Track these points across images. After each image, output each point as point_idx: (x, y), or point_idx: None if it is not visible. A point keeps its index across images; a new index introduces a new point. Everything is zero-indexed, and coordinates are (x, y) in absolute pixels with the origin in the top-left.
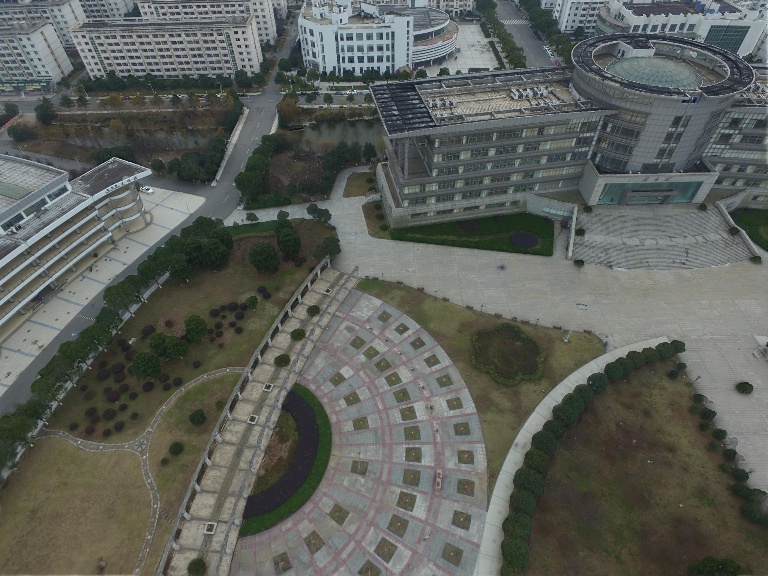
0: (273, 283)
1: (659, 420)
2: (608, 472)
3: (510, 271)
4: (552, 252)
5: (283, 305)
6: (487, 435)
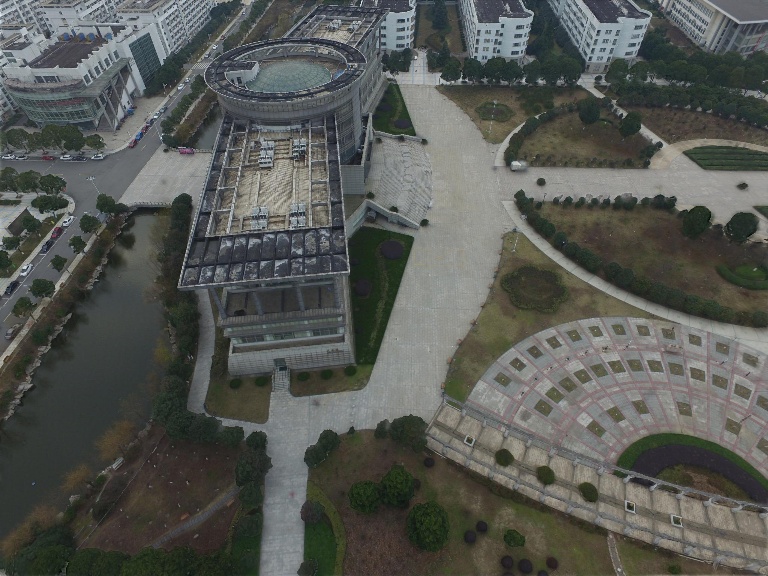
0: (455, 521)
1: (576, 223)
2: (624, 256)
3: (432, 269)
4: (409, 236)
5: (495, 502)
6: (619, 314)
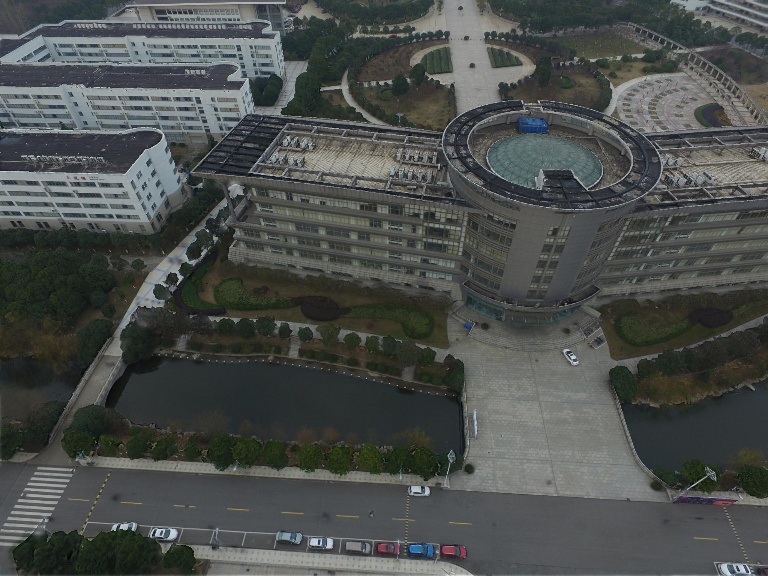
0: None
1: None
2: None
3: None
4: None
5: None
6: None
